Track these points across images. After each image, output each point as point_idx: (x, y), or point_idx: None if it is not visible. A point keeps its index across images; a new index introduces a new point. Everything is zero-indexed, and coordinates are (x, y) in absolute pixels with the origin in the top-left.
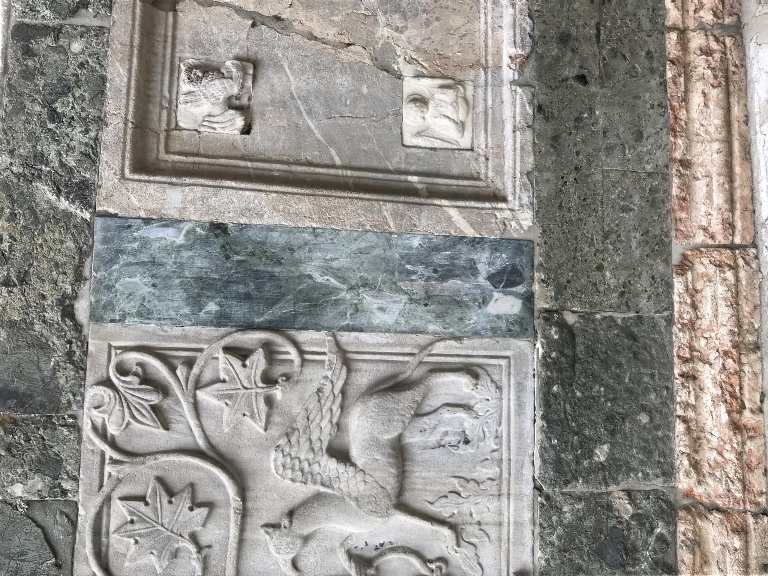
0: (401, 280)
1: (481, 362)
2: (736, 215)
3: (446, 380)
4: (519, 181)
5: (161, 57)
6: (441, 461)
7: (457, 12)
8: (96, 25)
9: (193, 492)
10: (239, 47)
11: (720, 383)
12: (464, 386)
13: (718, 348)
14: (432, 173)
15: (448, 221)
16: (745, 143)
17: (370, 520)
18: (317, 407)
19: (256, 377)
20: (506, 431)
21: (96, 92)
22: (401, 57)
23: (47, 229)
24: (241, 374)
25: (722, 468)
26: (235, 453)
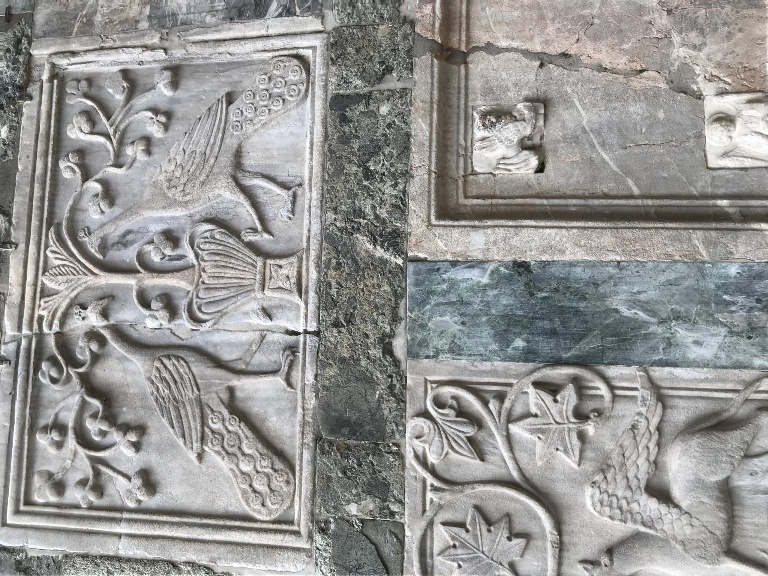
0: (719, 312)
1: None
2: None
3: None
4: None
5: (456, 108)
6: None
7: (764, 19)
8: (400, 88)
9: (510, 523)
10: (528, 89)
11: None
12: None
13: None
14: (744, 195)
15: None
16: None
17: (699, 567)
18: (633, 444)
19: (568, 412)
20: None
21: (402, 148)
22: (700, 76)
23: (367, 275)
24: (553, 409)
25: None
26: (549, 487)
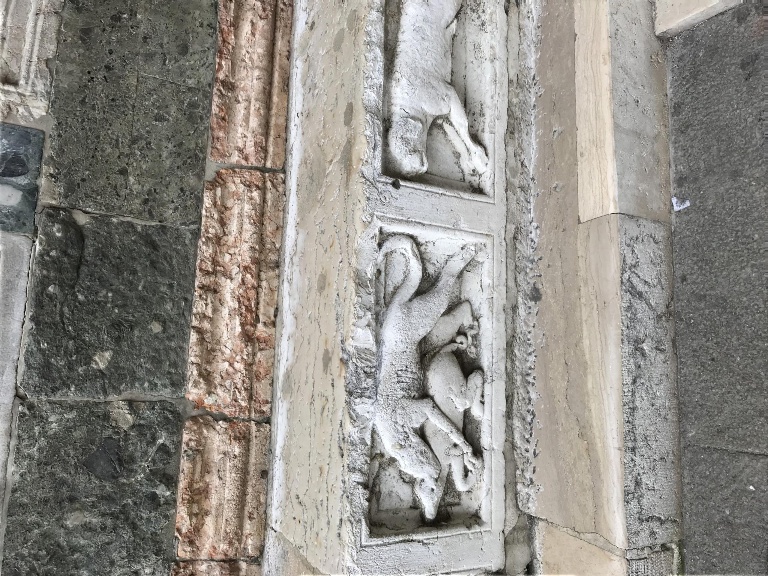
0: None
1: None
2: (270, 141)
3: None
4: (35, 66)
5: None
6: None
7: None
8: None
9: None
10: None
11: (238, 298)
12: None
13: (239, 264)
14: None
15: None
16: (284, 75)
17: None
18: None
19: None
20: None
21: None
22: None
23: None
24: None
25: (232, 379)
26: None
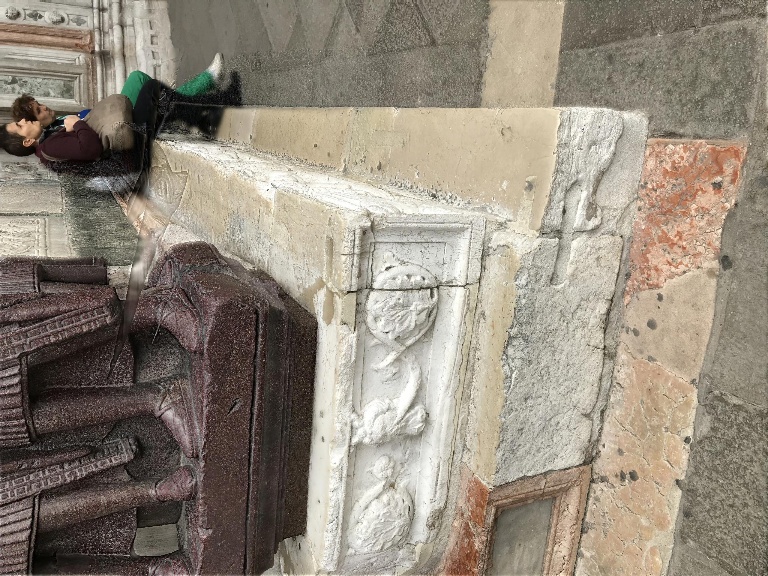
0: None
1: None
2: None
3: (31, 162)
4: None
5: None
6: None
7: None
8: None
9: None
10: None
11: None
12: (36, 163)
13: None
14: None
15: None
16: None
17: None
18: None
19: None
20: None
21: None
22: None
23: None
24: None
25: None
26: None
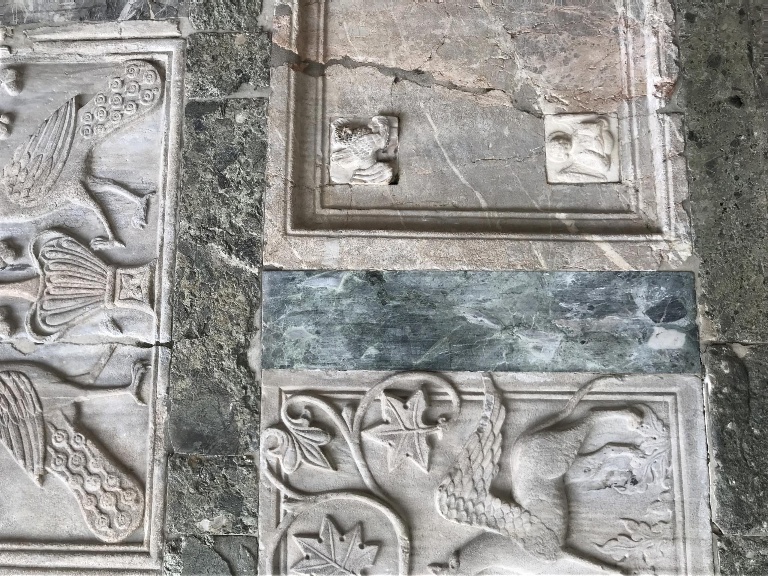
0: (555, 318)
1: (645, 399)
2: None
3: (609, 419)
4: (674, 211)
5: (313, 119)
6: (608, 502)
7: (596, 46)
8: (257, 96)
9: (362, 530)
10: (384, 103)
11: None
12: (628, 424)
13: None
14: (580, 208)
15: (601, 256)
16: None
17: (538, 562)
18: (478, 447)
19: (417, 418)
20: (677, 471)
21: (259, 157)
22: (541, 96)
23: (222, 285)
24: (403, 416)
25: None
26: (400, 493)
